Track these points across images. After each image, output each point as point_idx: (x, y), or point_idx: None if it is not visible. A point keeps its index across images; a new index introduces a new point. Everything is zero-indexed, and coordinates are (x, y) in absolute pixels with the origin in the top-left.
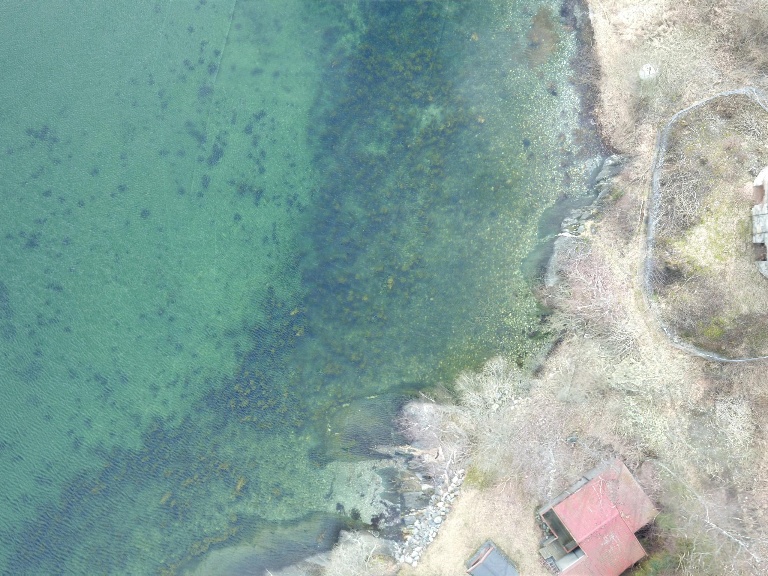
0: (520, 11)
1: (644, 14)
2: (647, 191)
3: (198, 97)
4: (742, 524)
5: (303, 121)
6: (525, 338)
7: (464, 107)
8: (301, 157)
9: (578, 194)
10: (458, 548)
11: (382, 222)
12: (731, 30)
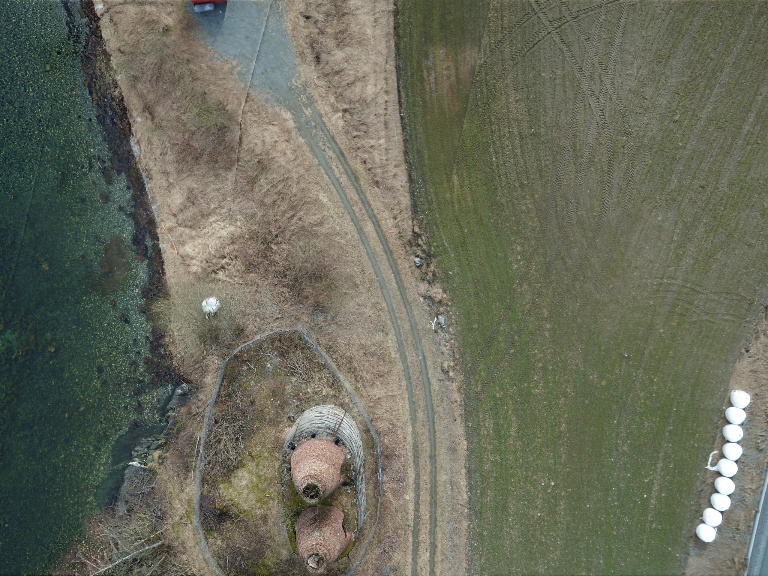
0: (93, 239)
1: (209, 246)
2: (205, 427)
3: None
4: None
5: None
6: None
7: (39, 334)
8: None
9: (151, 422)
10: None
11: None
12: (287, 267)
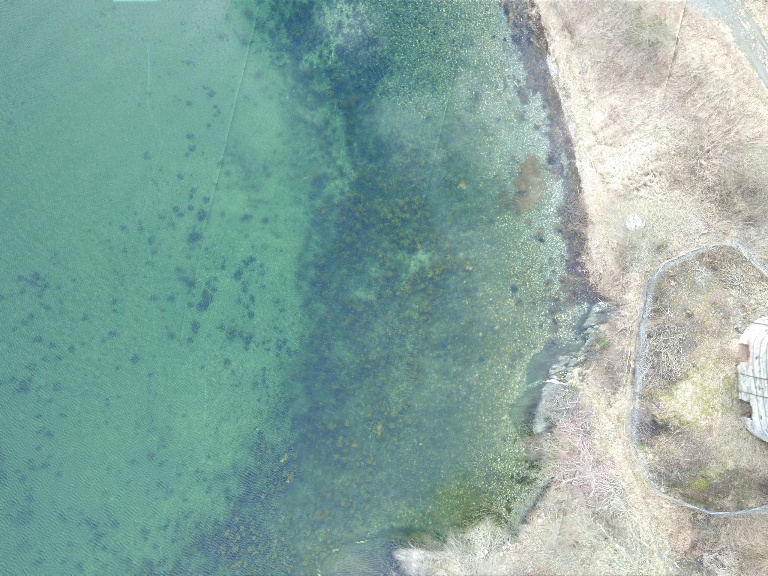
0: (507, 158)
1: (630, 164)
2: (634, 342)
3: (188, 243)
4: None
5: (292, 266)
6: (514, 483)
7: (452, 253)
8: (290, 302)
9: (566, 340)
10: None
11: (371, 368)
12: (717, 182)
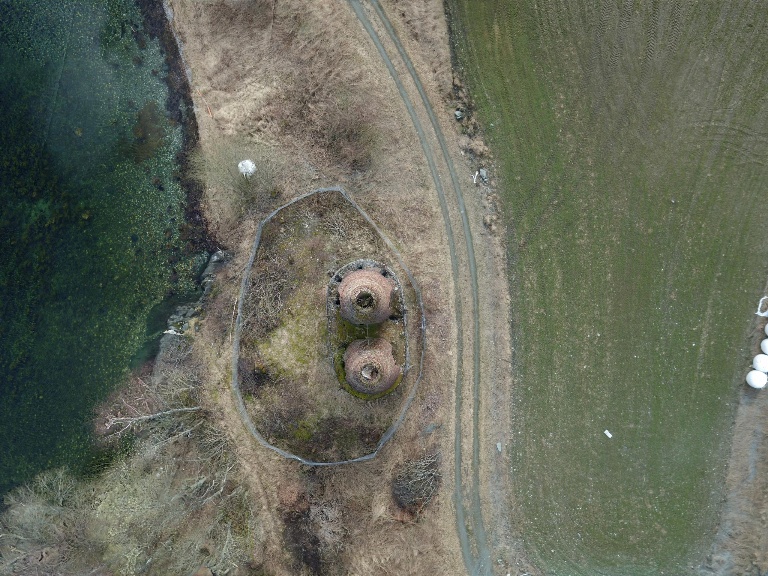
0: (126, 105)
1: (244, 109)
2: (242, 290)
3: None
4: None
5: None
6: (134, 437)
7: (72, 202)
8: None
9: (186, 290)
10: None
11: None
12: (325, 126)
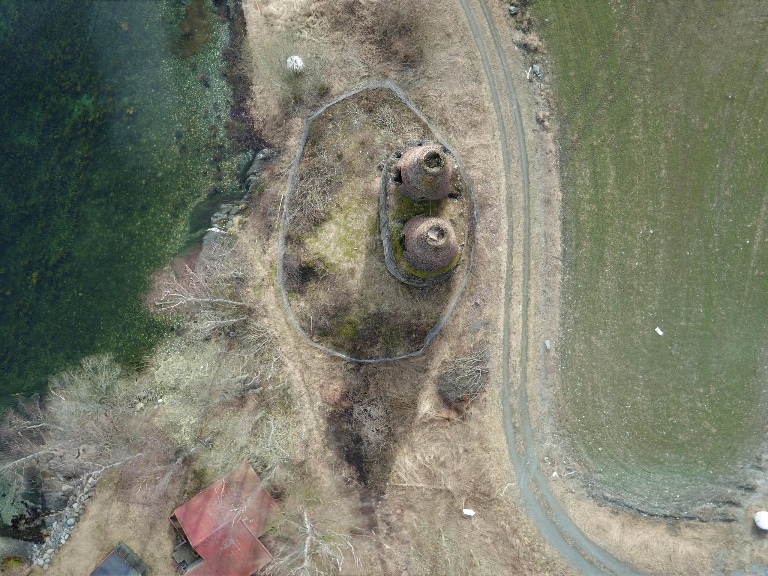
0: (174, 0)
1: (294, 5)
2: (289, 186)
3: None
4: (377, 529)
5: None
6: (174, 335)
7: (116, 98)
8: None
9: (230, 188)
10: (90, 551)
11: (30, 214)
12: (376, 22)
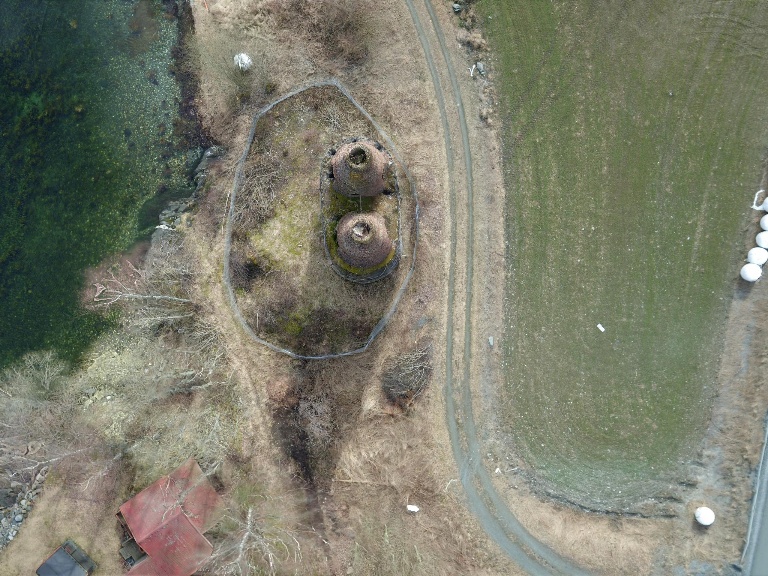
0: None
1: (241, 3)
2: (235, 183)
3: None
4: (323, 526)
5: None
6: (123, 332)
7: (65, 96)
8: None
9: (179, 186)
10: (37, 547)
11: None
12: (322, 20)
